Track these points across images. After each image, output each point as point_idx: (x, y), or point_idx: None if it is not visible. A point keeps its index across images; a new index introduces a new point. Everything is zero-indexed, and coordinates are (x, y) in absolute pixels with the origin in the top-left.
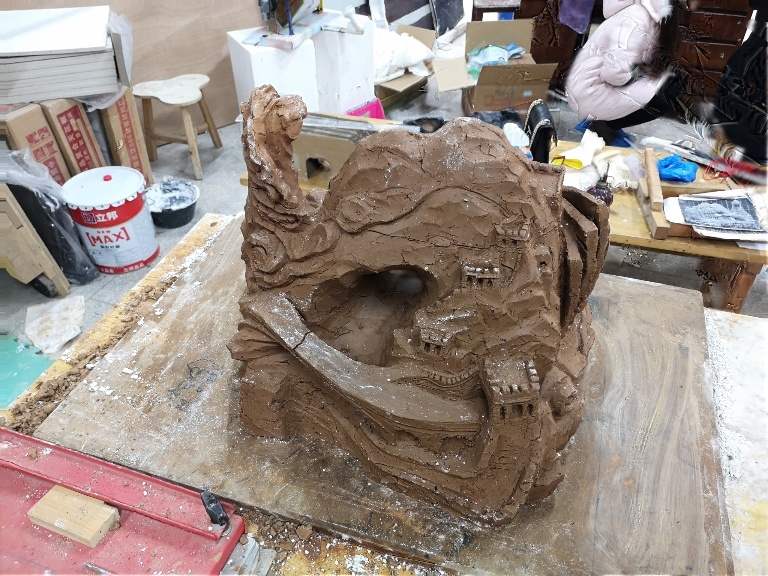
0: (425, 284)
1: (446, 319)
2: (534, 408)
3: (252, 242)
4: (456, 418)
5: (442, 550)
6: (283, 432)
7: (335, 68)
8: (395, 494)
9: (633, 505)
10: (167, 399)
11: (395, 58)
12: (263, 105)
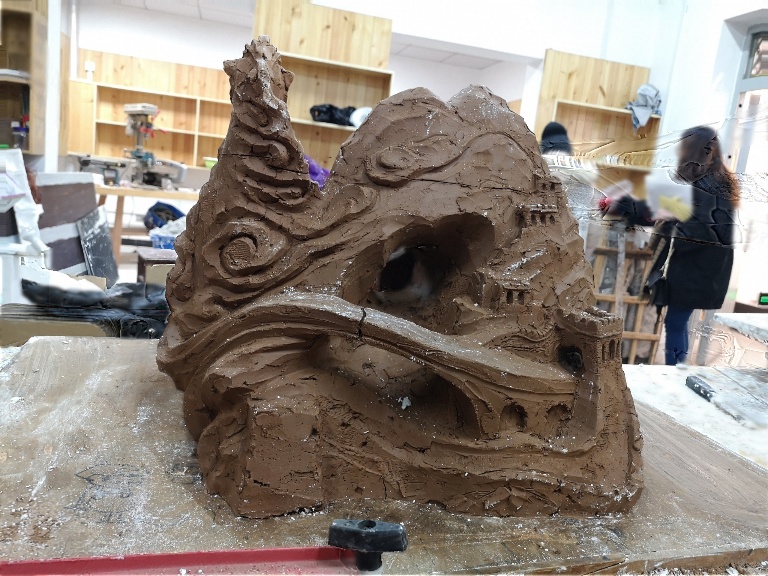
0: (461, 255)
1: (516, 266)
2: (619, 348)
3: (233, 231)
4: (558, 376)
5: (610, 548)
6: (321, 491)
7: (6, 296)
8: (506, 520)
9: (690, 468)
10: (71, 517)
11: (70, 296)
12: (271, 52)
